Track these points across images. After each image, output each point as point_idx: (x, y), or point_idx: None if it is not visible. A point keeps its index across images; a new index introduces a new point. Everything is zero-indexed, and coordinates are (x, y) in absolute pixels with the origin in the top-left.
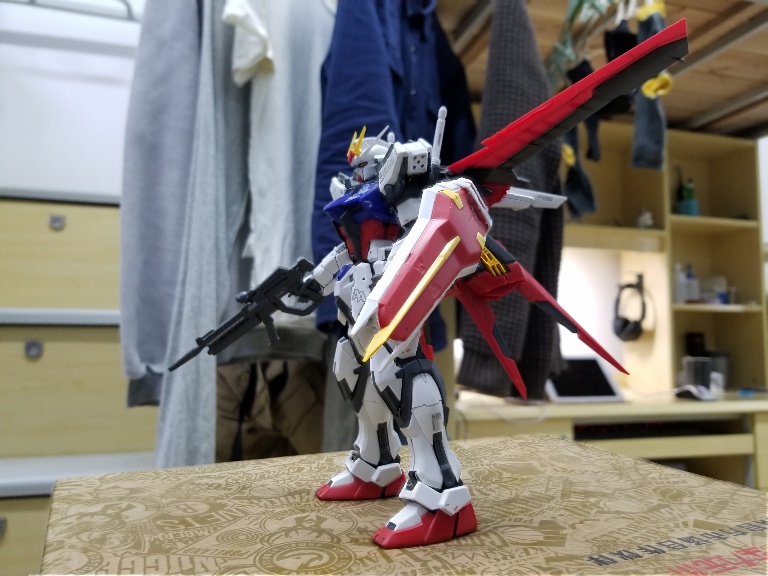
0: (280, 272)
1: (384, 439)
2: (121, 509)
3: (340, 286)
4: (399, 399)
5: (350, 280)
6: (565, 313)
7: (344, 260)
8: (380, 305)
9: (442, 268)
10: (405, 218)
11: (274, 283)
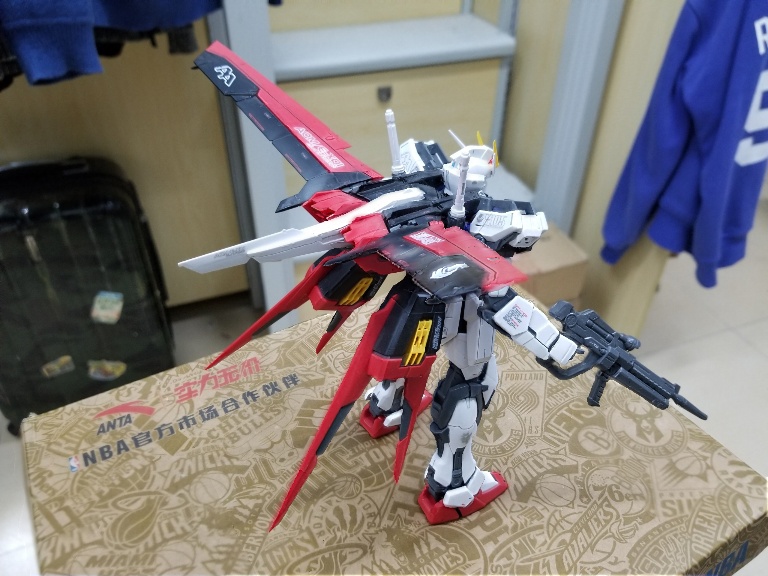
0: None
1: None
2: (643, 429)
3: None
4: None
5: None
6: None
7: None
8: None
9: None
10: None
11: None
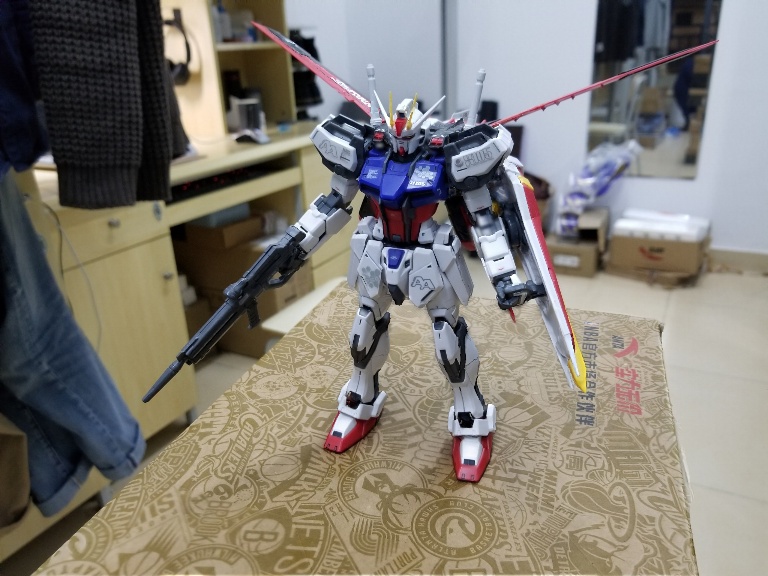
0: (275, 253)
1: None
2: None
3: (398, 275)
4: (459, 363)
5: (405, 266)
6: None
7: (333, 221)
8: (571, 335)
9: None
10: (479, 205)
11: (267, 267)
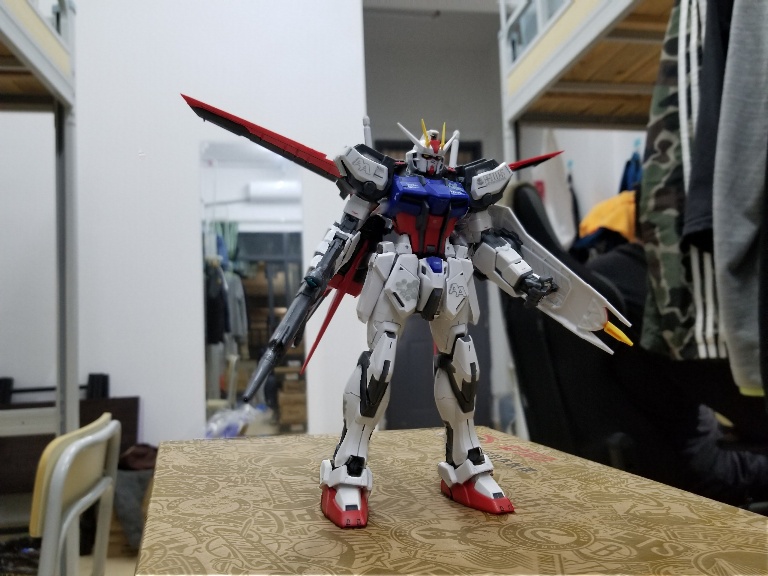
0: (338, 249)
1: None
2: None
3: None
4: None
5: None
6: None
7: None
8: None
9: None
10: (486, 225)
11: (331, 262)
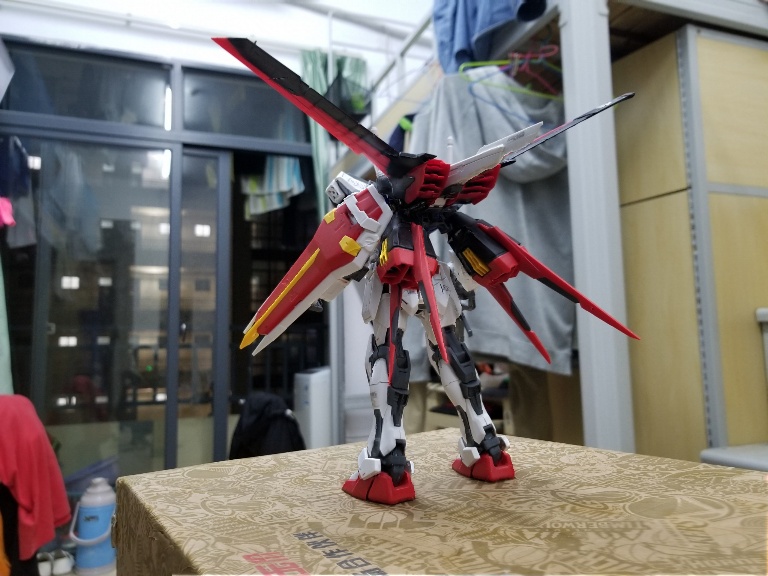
0: None
1: (466, 422)
2: None
3: None
4: None
5: None
6: (429, 291)
7: (453, 260)
8: None
9: (302, 278)
10: None
11: None
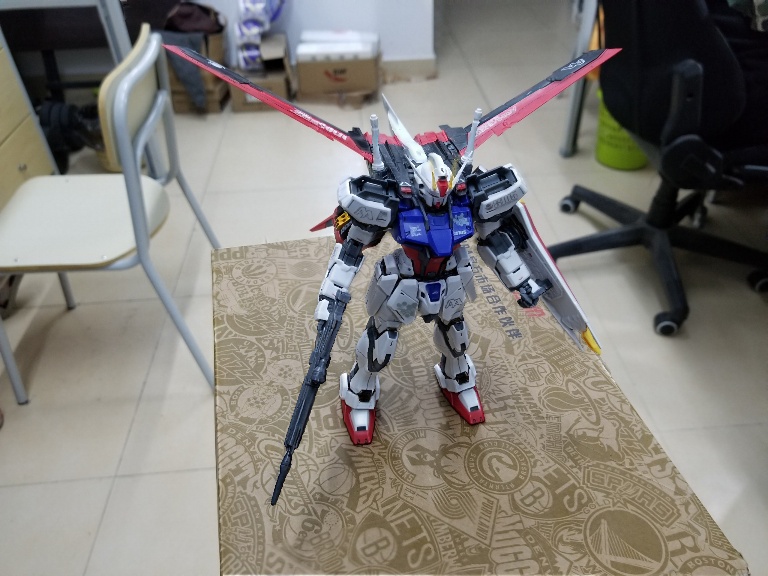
0: None
1: None
2: None
3: None
4: None
5: (441, 295)
6: None
7: None
8: None
9: None
10: None
11: None
